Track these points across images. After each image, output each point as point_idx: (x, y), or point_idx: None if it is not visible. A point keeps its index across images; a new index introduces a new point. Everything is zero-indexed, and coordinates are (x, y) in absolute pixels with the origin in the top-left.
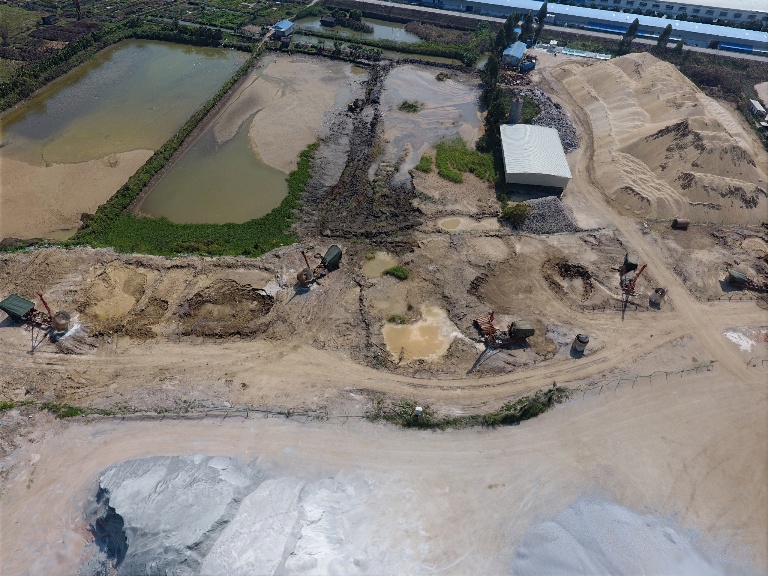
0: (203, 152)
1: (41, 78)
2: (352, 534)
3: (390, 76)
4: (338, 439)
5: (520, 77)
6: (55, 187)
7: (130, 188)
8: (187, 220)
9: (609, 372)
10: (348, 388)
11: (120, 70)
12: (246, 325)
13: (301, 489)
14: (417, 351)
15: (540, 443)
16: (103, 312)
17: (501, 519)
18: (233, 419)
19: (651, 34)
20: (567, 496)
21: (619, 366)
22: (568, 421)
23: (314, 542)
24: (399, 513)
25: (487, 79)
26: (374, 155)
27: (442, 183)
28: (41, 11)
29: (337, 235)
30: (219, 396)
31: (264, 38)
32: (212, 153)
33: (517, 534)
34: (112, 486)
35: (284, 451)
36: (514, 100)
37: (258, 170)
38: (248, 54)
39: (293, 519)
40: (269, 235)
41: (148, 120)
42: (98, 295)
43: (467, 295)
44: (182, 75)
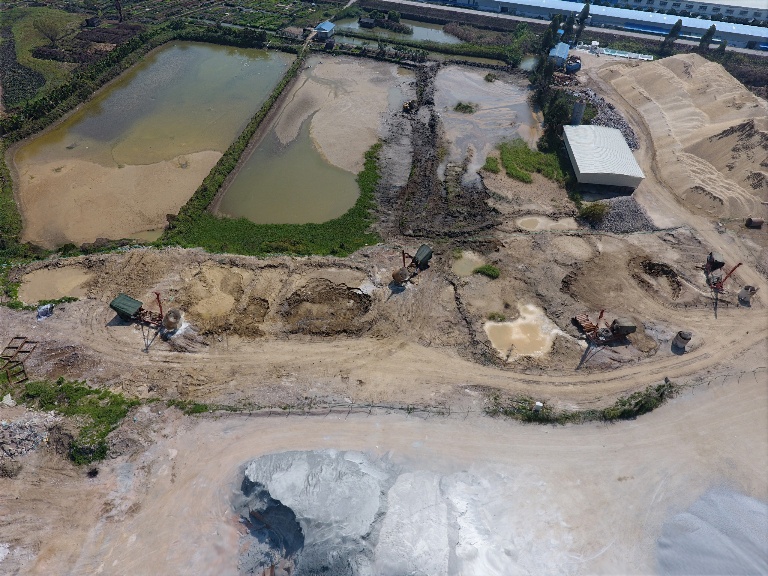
0: (269, 153)
1: (97, 80)
2: (496, 525)
3: (439, 77)
4: (463, 434)
5: (568, 78)
6: (132, 188)
7: (208, 189)
8: (267, 220)
9: (713, 368)
10: (462, 384)
11: (171, 72)
12: (351, 323)
13: (439, 482)
14: (522, 348)
15: (660, 437)
16: (205, 311)
17: (637, 510)
18: (357, 415)
19: (689, 35)
20: (696, 488)
21: (722, 362)
22: (683, 416)
23: (469, 533)
24: (537, 505)
25: (541, 80)
26: (440, 156)
27: (512, 183)
28: (83, 13)
29: (421, 235)
30: (338, 392)
31: (307, 39)
32: (278, 154)
33: (655, 525)
34: (263, 479)
35: (413, 446)
36: (578, 101)
37: (327, 171)
38: (293, 55)
39: (444, 511)
40: (351, 235)
41: (209, 121)
42: (198, 294)
43: (561, 293)
44: (233, 77)
